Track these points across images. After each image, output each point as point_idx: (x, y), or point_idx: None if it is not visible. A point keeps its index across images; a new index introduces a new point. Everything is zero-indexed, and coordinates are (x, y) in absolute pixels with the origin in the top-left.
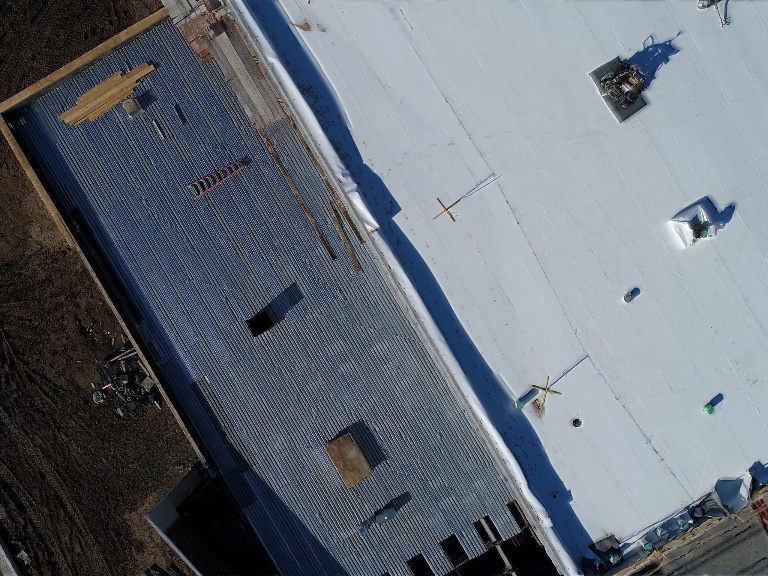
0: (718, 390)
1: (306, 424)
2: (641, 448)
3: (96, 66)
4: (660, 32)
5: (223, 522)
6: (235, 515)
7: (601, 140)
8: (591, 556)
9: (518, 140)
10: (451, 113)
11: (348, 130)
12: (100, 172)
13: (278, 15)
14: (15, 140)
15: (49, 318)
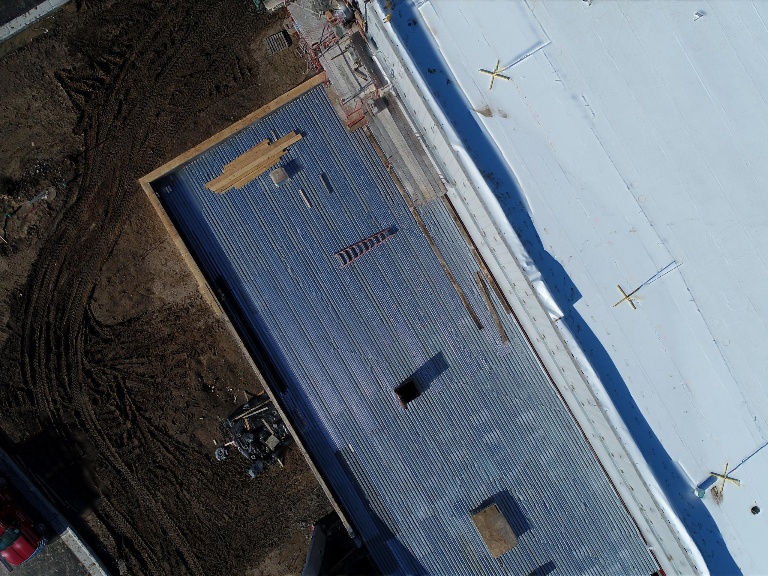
0: None
1: (450, 493)
2: None
3: (242, 134)
4: None
5: None
6: None
7: None
8: None
9: (700, 227)
10: (632, 200)
11: (529, 217)
12: (245, 240)
13: (459, 101)
14: (164, 210)
15: (171, 375)
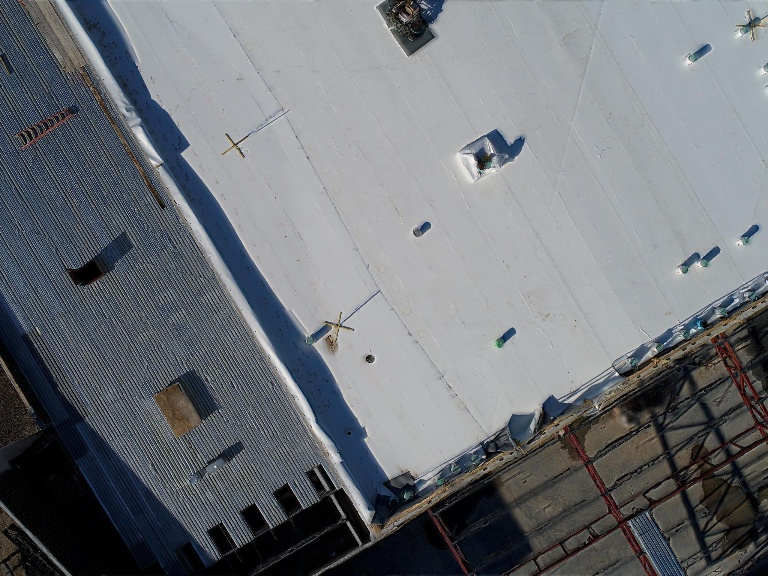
0: (510, 324)
1: (137, 374)
2: (435, 384)
3: None
4: None
5: (56, 474)
6: (68, 467)
7: (389, 74)
8: (386, 493)
9: (307, 74)
10: (239, 48)
11: (135, 66)
12: None
13: None
14: None
15: None
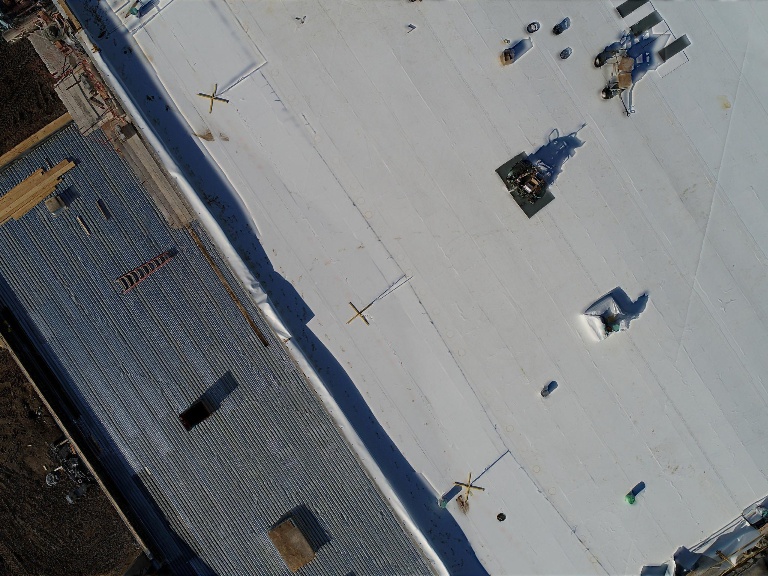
0: (639, 478)
1: (248, 510)
2: (566, 539)
3: (17, 165)
4: (565, 124)
5: None
6: None
7: (511, 236)
8: None
9: (428, 240)
10: (359, 216)
11: (257, 239)
12: (28, 271)
13: (180, 126)
14: None
15: None
